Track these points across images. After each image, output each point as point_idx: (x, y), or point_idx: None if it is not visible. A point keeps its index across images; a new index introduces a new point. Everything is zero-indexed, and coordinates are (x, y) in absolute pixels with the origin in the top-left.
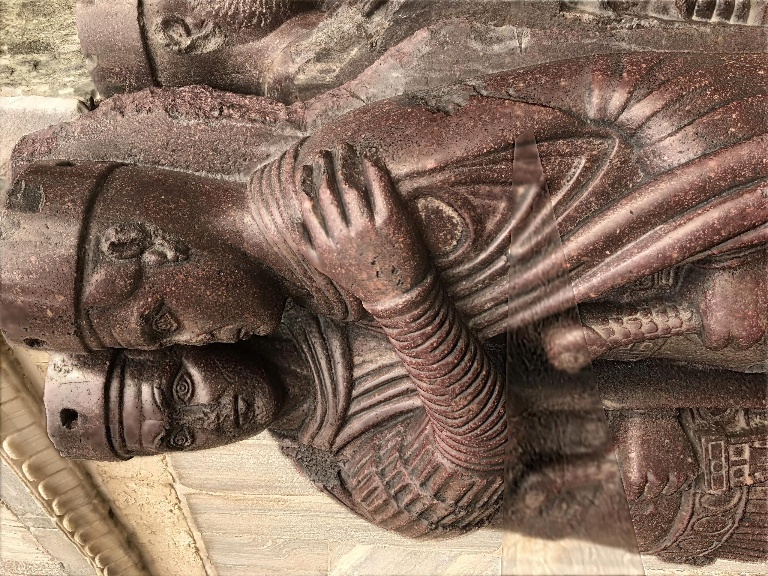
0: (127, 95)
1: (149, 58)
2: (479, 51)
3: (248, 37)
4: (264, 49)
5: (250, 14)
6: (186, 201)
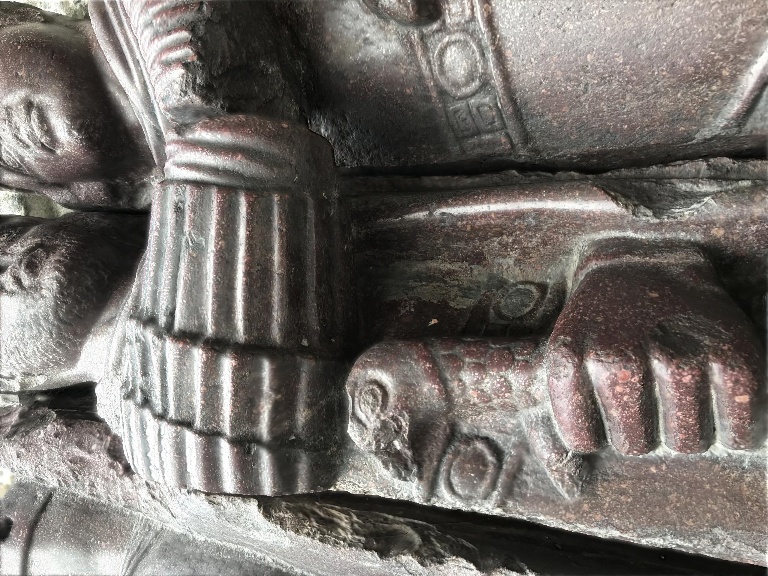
0: (8, 447)
1: (5, 391)
2: (240, 533)
3: (62, 369)
4: (84, 376)
5: (41, 363)
6: (88, 574)
